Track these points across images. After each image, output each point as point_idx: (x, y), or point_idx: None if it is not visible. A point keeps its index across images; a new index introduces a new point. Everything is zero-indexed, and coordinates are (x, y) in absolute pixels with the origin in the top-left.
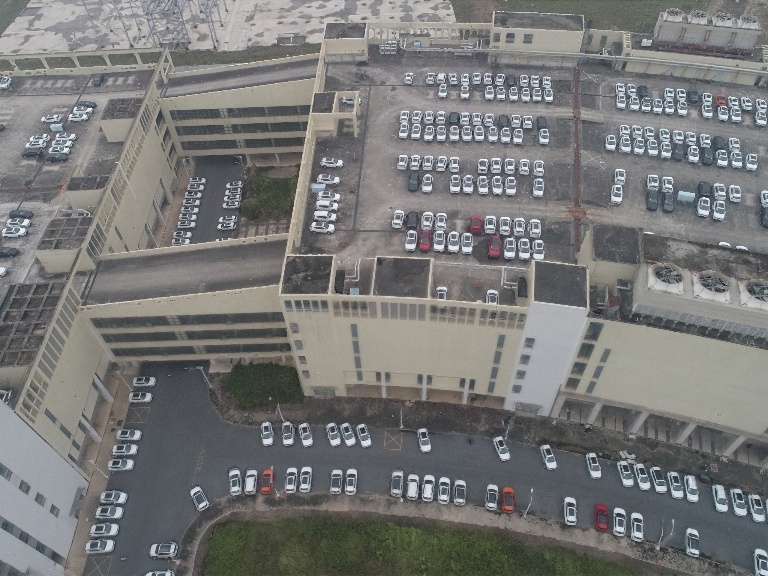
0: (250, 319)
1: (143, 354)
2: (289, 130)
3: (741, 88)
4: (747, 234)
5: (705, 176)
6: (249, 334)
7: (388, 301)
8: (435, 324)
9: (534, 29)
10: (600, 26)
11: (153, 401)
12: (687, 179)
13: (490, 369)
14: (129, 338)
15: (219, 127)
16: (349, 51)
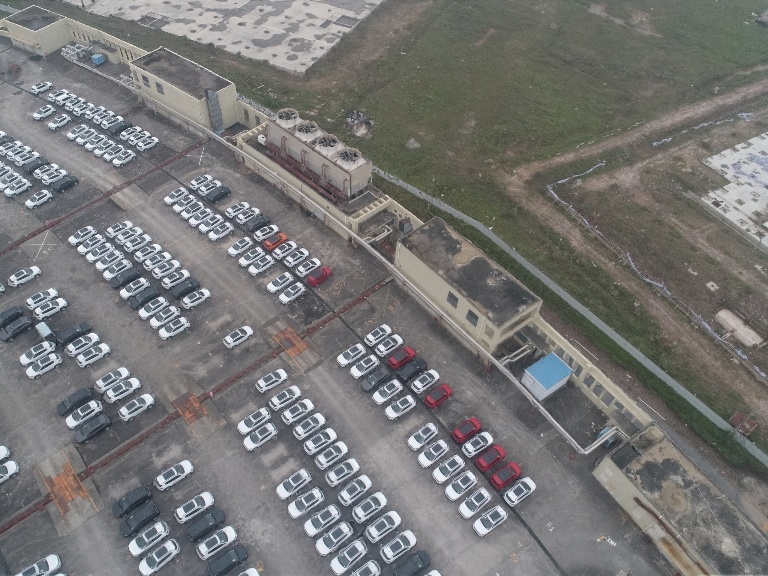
0: None
1: None
2: None
3: (330, 237)
4: (32, 409)
5: (110, 319)
6: None
7: None
8: None
9: (161, 79)
10: (459, 115)
11: None
12: (88, 313)
13: None
14: None
15: None
16: (26, 40)
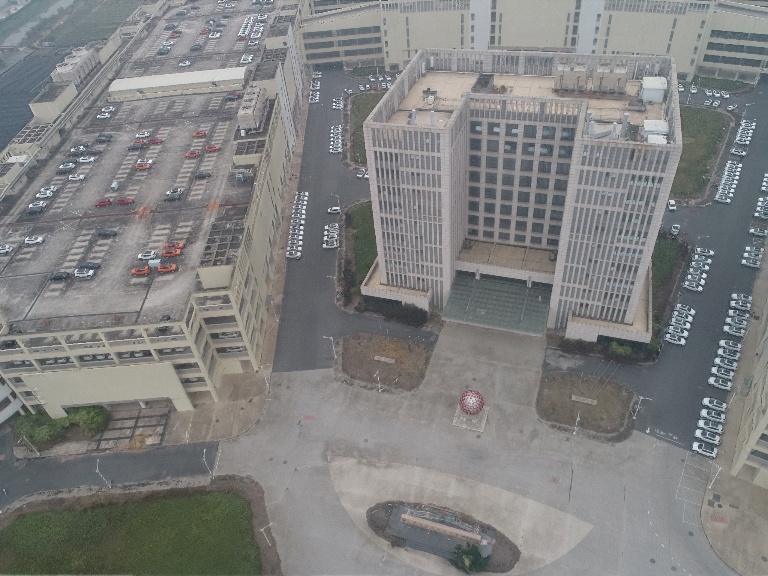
0: (365, 31)
1: (318, 58)
2: (367, 1)
3: None
4: None
5: None
6: (363, 42)
7: (420, 1)
8: (437, 12)
9: None
10: None
11: (322, 78)
12: None
13: (460, 38)
14: (315, 47)
15: (334, 1)
16: None
